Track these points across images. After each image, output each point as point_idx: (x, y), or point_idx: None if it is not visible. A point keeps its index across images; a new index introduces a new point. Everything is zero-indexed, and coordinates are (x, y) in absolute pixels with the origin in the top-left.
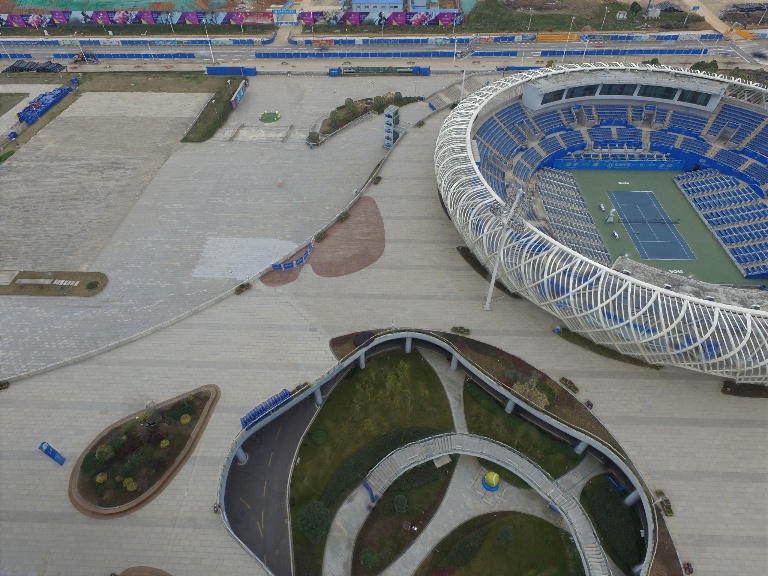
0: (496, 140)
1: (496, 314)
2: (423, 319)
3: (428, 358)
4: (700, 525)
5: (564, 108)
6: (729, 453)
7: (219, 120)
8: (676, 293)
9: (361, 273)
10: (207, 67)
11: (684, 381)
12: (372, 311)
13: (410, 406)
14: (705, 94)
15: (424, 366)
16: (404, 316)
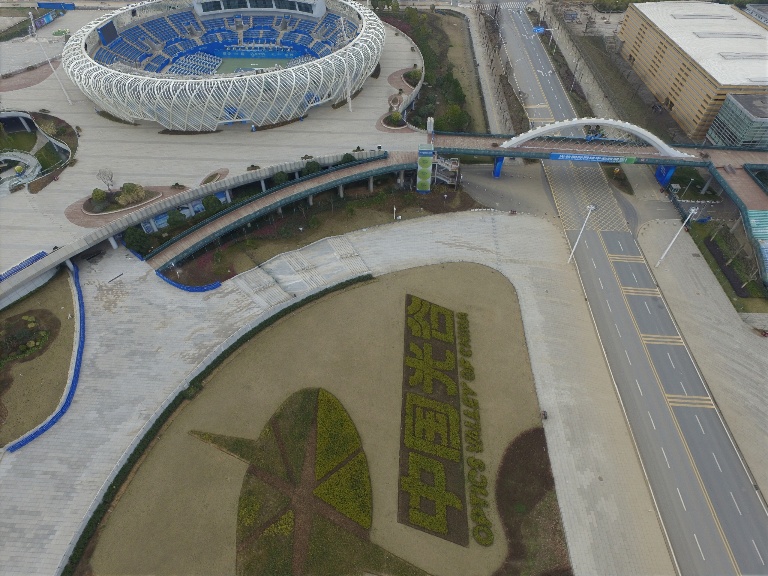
0: (160, 31)
1: (73, 106)
2: (29, 108)
3: (39, 134)
4: (82, 169)
5: (229, 17)
6: (130, 150)
7: (19, 32)
8: (120, 72)
9: (15, 91)
10: (38, 3)
11: (143, 129)
12: (4, 105)
13: (1, 145)
14: (308, 4)
15: (33, 137)
16: (20, 106)
